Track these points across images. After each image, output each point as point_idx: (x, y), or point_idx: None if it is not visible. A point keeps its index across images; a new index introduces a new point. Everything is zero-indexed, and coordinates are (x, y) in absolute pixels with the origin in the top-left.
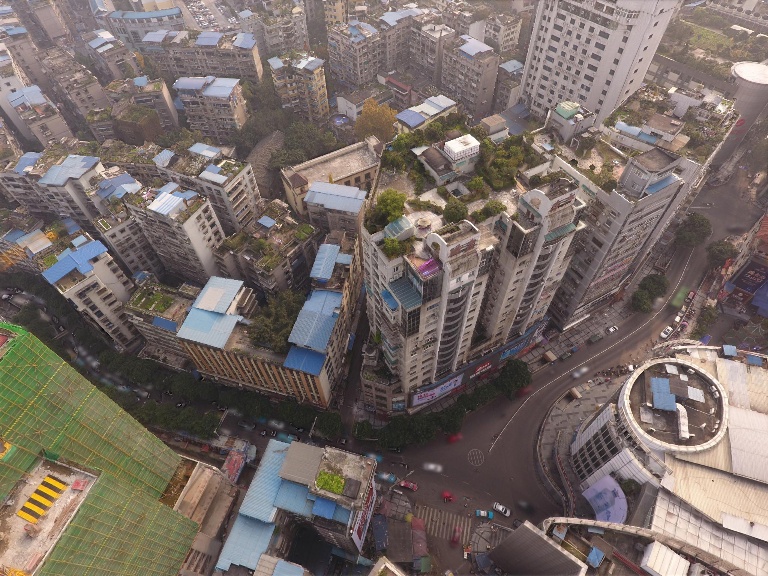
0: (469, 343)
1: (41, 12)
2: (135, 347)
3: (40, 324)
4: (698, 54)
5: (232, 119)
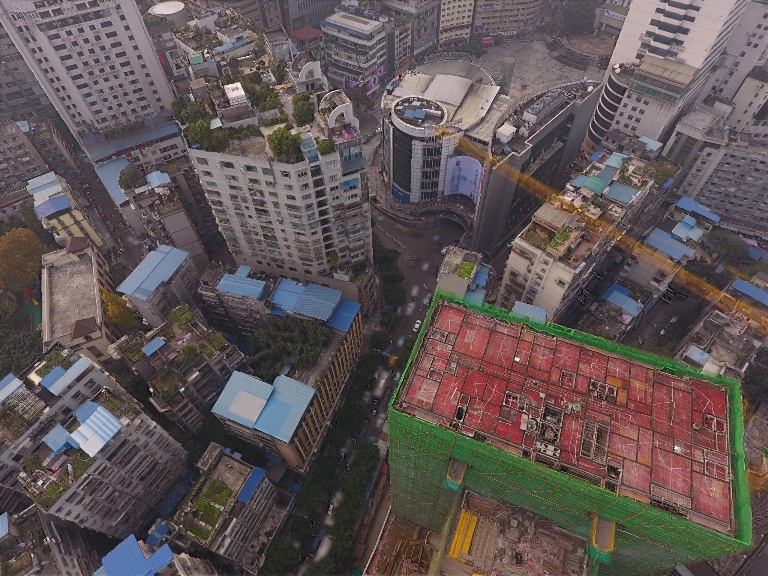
0: None
1: None
2: None
3: None
4: None
5: None
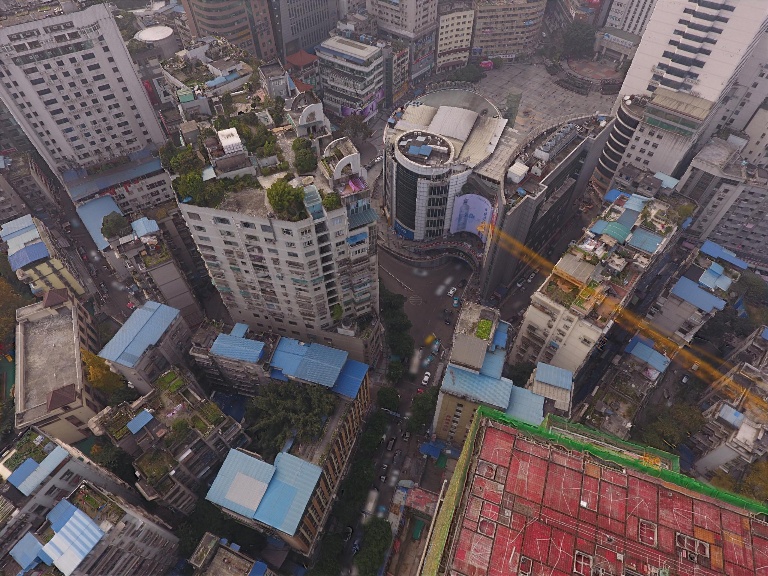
0: None
1: None
2: None
3: None
4: None
5: None
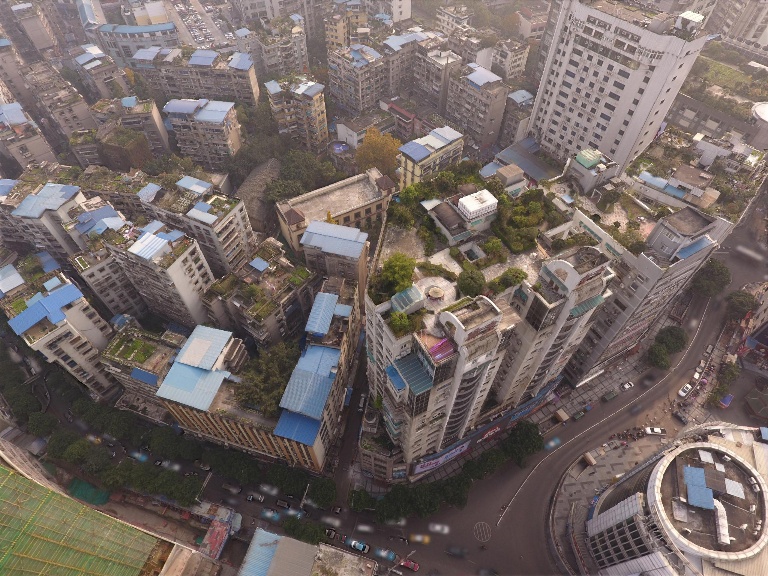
0: (478, 411)
1: (28, 23)
2: (112, 394)
3: (9, 367)
4: (715, 91)
5: (225, 144)
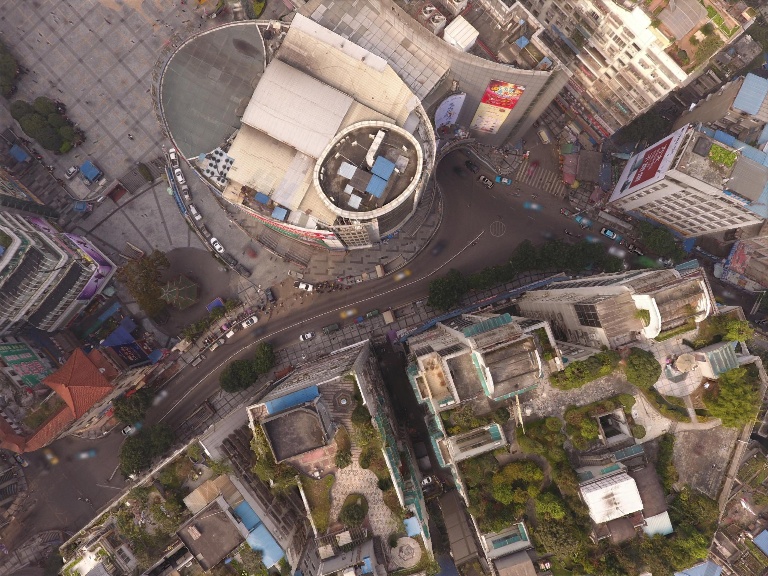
0: None
1: None
2: None
3: None
4: None
5: None
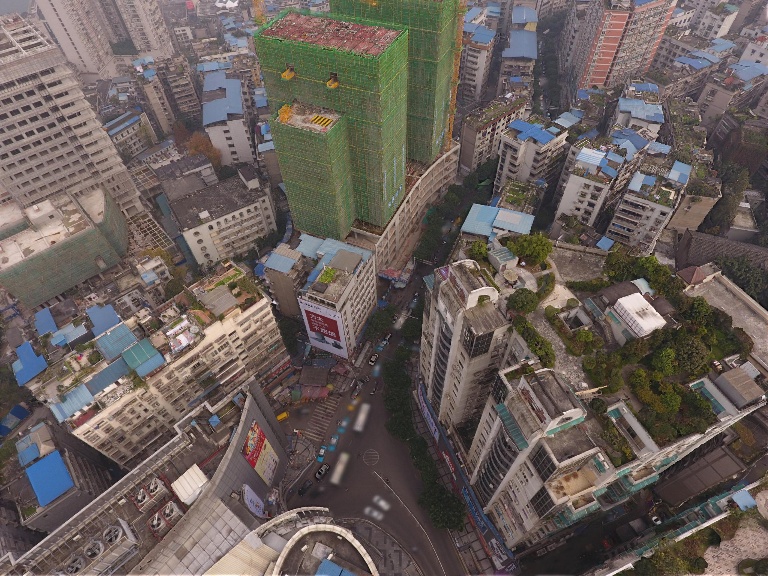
0: None
1: None
2: None
3: None
4: None
5: None
